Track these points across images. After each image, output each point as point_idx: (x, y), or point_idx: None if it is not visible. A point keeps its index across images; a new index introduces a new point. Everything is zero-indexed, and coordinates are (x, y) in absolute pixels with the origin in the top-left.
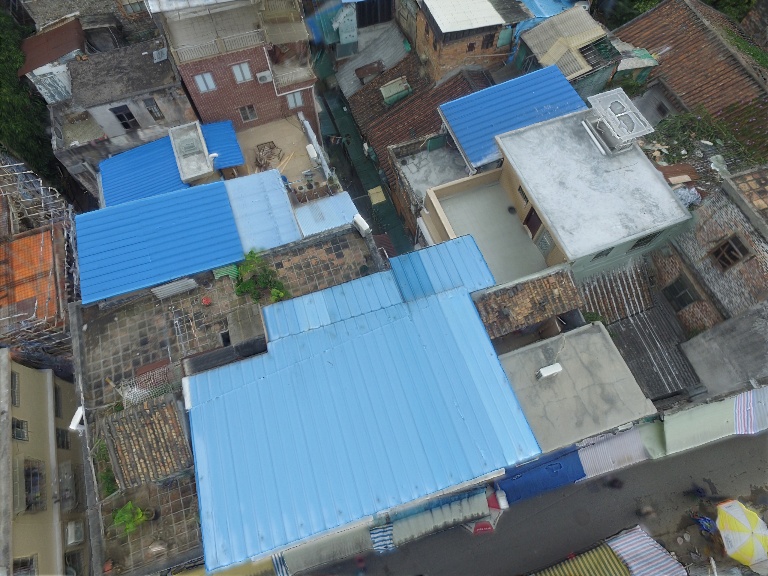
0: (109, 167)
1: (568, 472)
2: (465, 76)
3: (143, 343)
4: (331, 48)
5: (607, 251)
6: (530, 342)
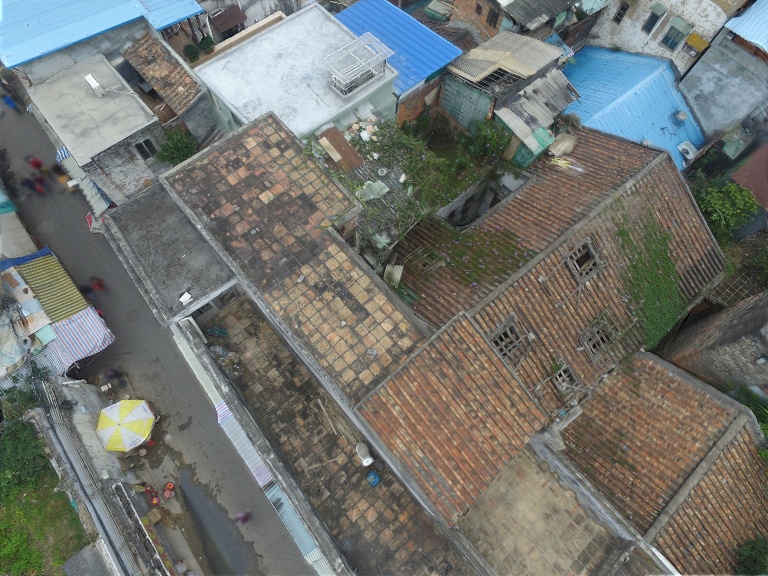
0: None
1: None
2: (461, 32)
3: None
4: None
5: None
6: None
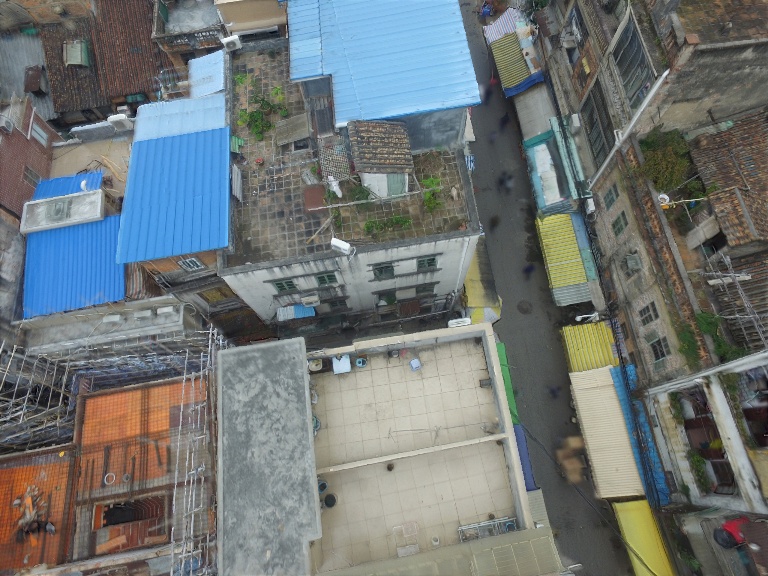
0: (37, 305)
1: None
2: None
3: (282, 215)
4: None
5: None
6: None
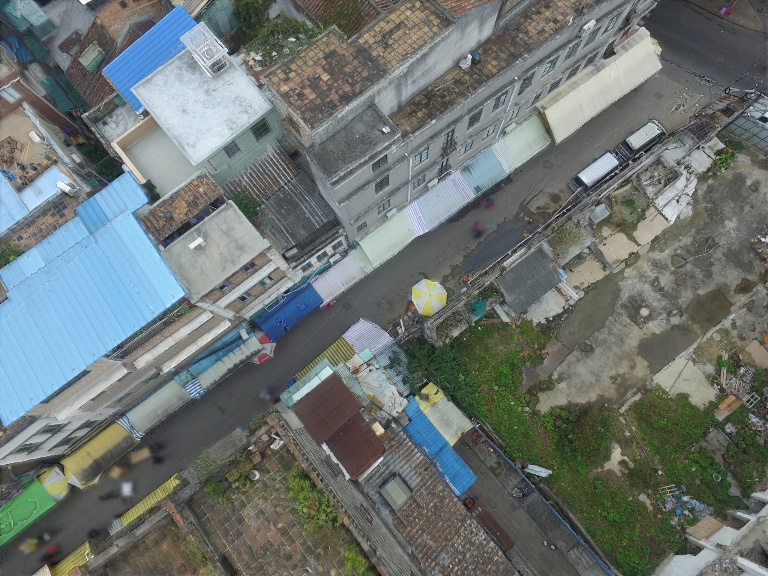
0: None
1: (310, 303)
2: (134, 29)
3: None
4: (29, 32)
5: (235, 148)
6: None
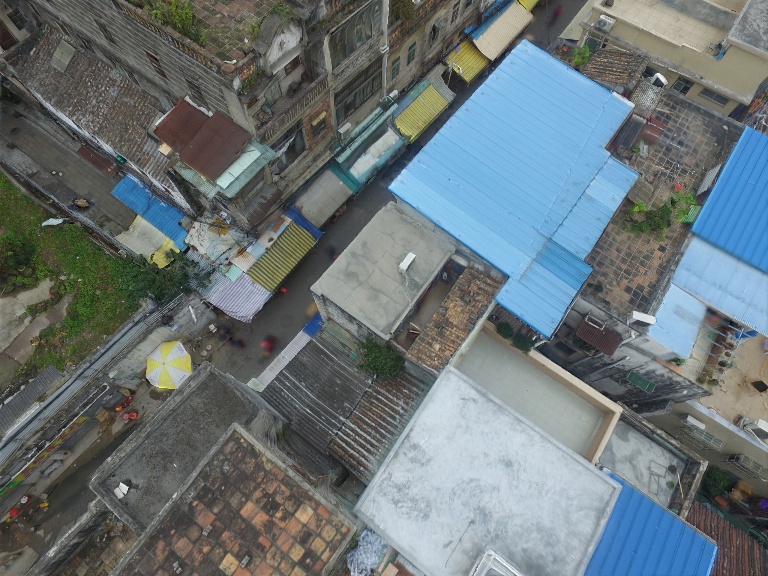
0: None
1: (317, 323)
2: None
3: (681, 142)
4: None
5: None
6: (423, 322)
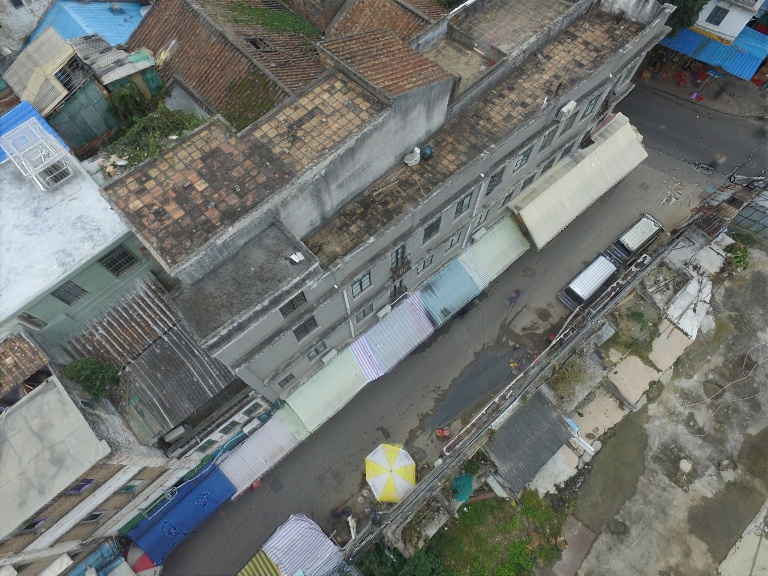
0: None
1: (216, 495)
2: None
3: None
4: None
5: (76, 290)
6: None
